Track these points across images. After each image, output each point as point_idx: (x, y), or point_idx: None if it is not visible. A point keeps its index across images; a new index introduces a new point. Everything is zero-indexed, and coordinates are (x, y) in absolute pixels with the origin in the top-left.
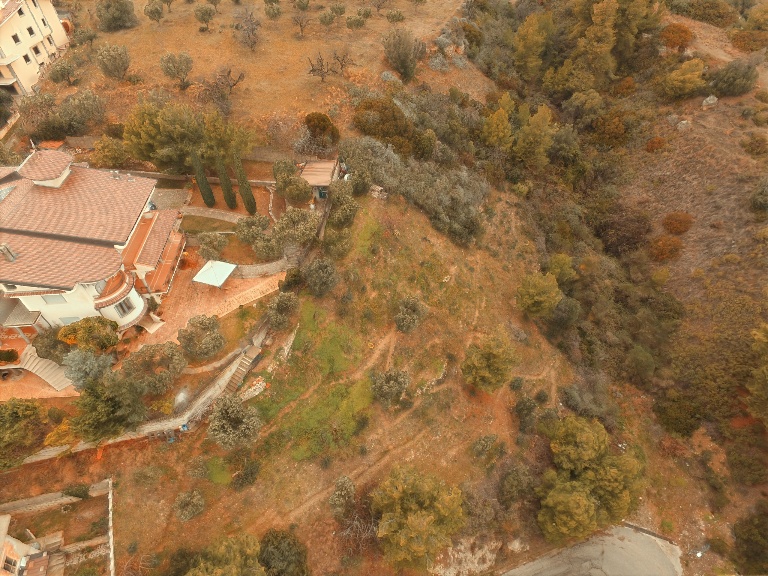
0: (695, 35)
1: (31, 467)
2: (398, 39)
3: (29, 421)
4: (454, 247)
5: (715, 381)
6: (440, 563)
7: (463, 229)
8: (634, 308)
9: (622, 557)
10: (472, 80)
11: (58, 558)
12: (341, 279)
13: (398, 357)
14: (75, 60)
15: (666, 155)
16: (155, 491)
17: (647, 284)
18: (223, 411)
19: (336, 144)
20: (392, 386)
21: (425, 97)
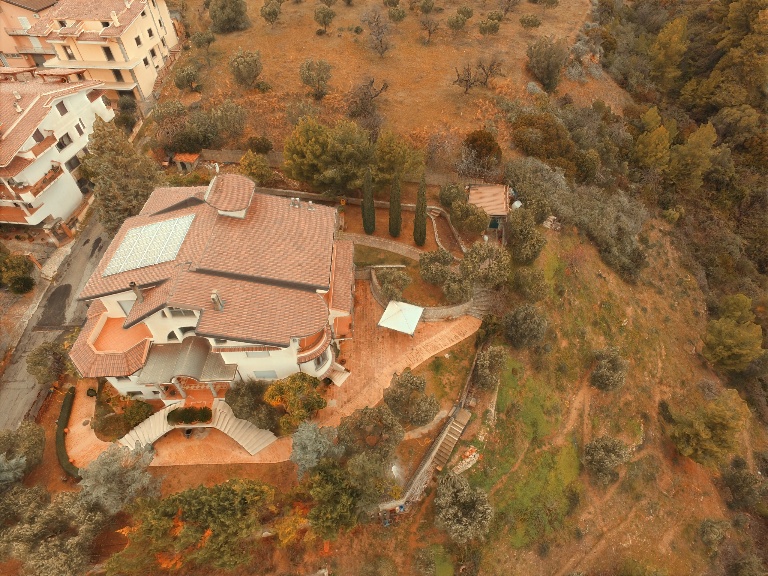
0: None
1: None
2: (550, 47)
3: (257, 508)
4: (622, 284)
5: None
6: None
7: (631, 263)
8: None
9: None
10: (608, 92)
11: None
12: None
13: (594, 417)
14: (194, 64)
15: None
16: None
17: None
18: (453, 495)
19: (500, 166)
20: (613, 460)
21: (572, 111)
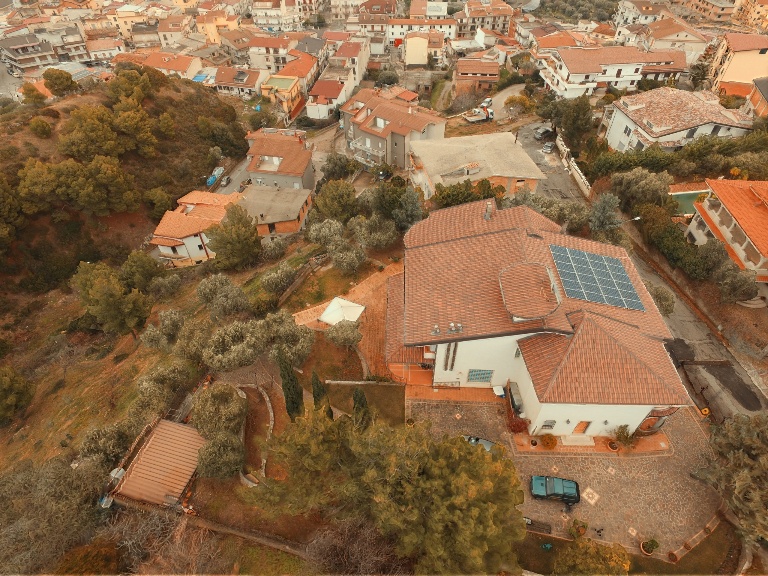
0: None
1: None
2: None
3: None
4: None
5: None
6: None
7: None
8: None
9: None
10: None
11: None
12: None
13: None
14: None
15: None
16: None
17: None
18: None
19: None
20: None
21: None
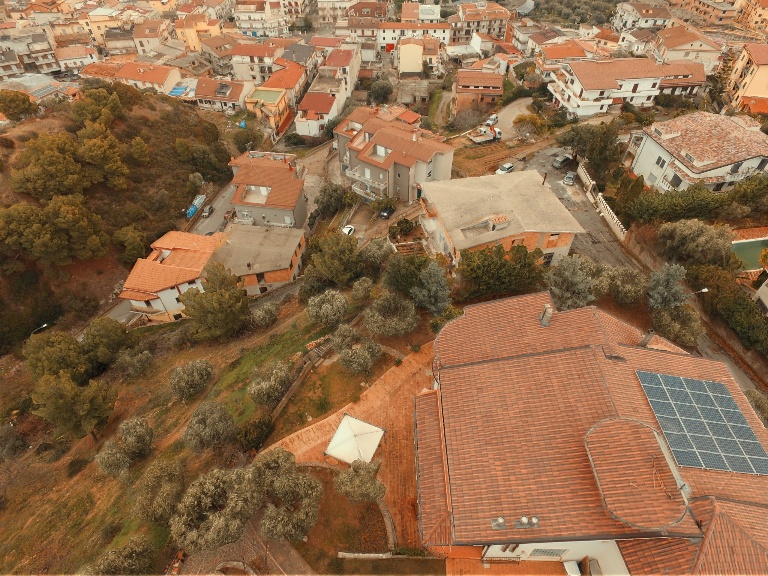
0: None
1: None
2: None
3: None
4: None
5: None
6: None
7: None
8: None
9: None
10: None
11: None
12: None
13: None
14: None
15: None
16: None
17: None
18: None
19: None
20: None
21: None
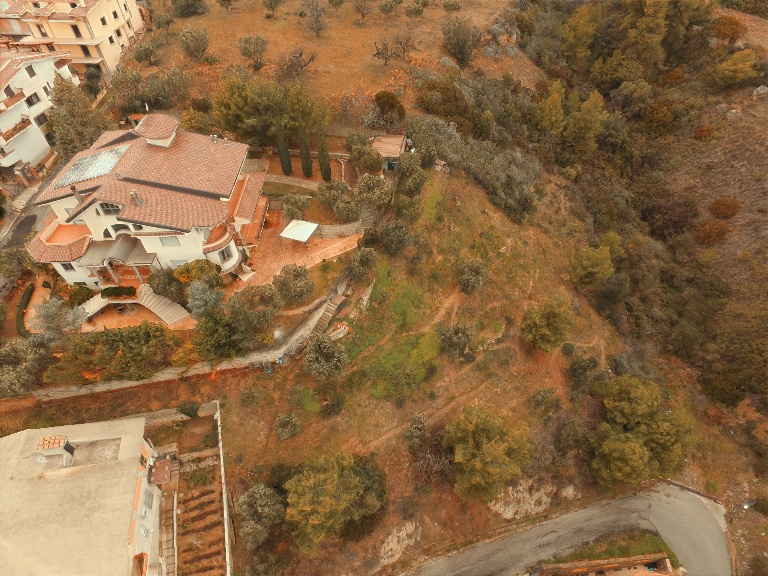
0: (746, 27)
1: (149, 387)
2: (458, 26)
3: (158, 341)
4: (509, 222)
5: (761, 355)
6: (501, 501)
7: (518, 205)
8: (680, 288)
9: (668, 511)
10: (523, 68)
11: (174, 465)
12: (413, 240)
13: (461, 316)
14: (154, 42)
15: (714, 143)
16: (256, 413)
17: (693, 265)
18: (317, 346)
19: (402, 121)
20: (461, 337)
21: (481, 82)
